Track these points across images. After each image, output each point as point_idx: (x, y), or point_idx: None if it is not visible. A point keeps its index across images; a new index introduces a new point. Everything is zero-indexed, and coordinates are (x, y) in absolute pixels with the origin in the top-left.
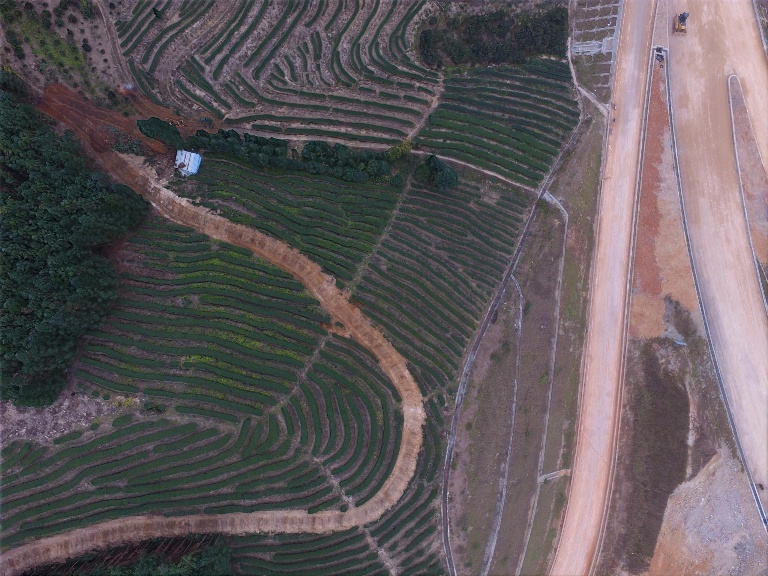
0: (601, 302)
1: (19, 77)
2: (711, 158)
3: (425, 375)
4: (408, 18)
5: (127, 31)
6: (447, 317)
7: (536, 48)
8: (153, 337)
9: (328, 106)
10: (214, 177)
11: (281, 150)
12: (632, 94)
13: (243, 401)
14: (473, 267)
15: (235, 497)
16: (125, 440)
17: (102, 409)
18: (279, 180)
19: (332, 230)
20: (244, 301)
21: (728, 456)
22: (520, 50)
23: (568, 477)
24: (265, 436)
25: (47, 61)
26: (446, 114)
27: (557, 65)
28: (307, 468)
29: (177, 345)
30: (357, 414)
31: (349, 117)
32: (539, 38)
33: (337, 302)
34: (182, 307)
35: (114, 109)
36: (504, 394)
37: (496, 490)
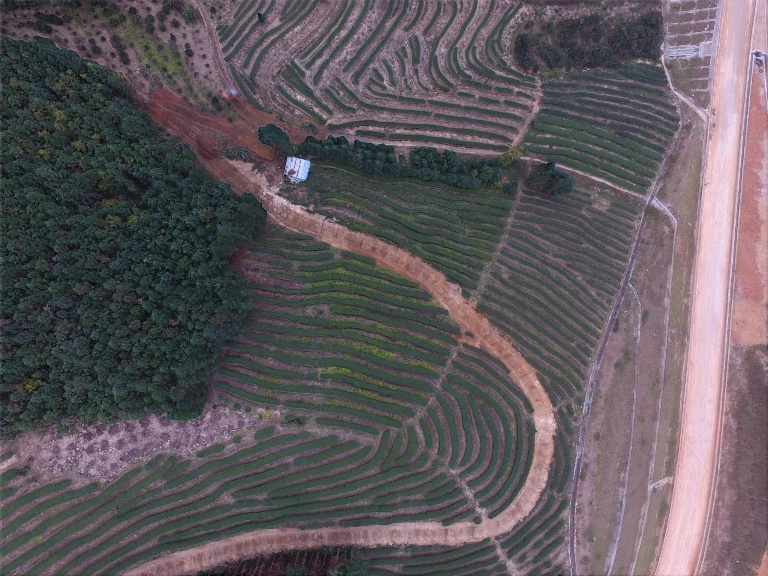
0: (702, 309)
1: (130, 83)
2: None
3: (555, 385)
4: (504, 22)
5: (228, 36)
6: (571, 326)
7: (630, 52)
8: (288, 348)
9: (429, 111)
10: (324, 184)
11: (394, 157)
12: (731, 99)
13: (381, 413)
14: (592, 275)
15: (372, 510)
16: (266, 453)
17: (244, 421)
18: (390, 187)
19: (451, 238)
20: (374, 311)
21: None
22: (613, 54)
23: (670, 485)
24: (403, 448)
25: (151, 66)
26: (549, 119)
27: (652, 69)
28: (444, 480)
29: (313, 356)
30: (492, 425)
31: (452, 123)
32: (634, 42)
33: (464, 311)
34: (313, 317)
35: (218, 115)
36: (625, 403)
37: (616, 500)
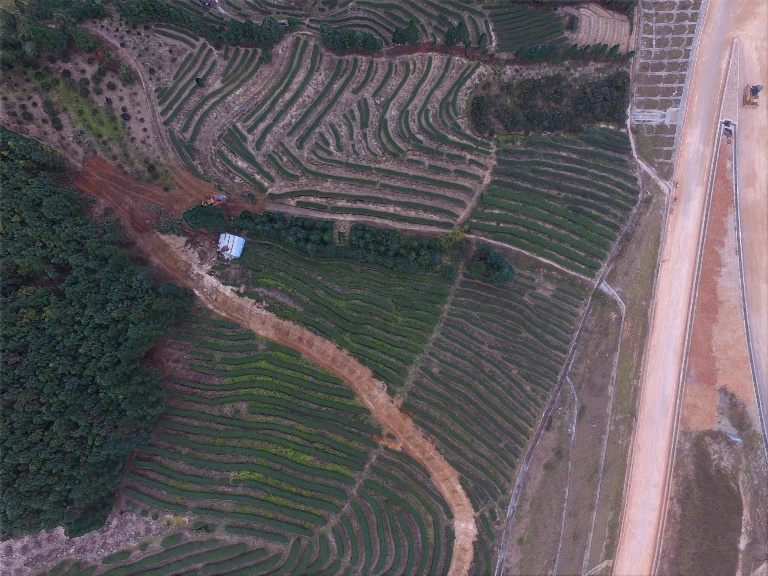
0: (652, 390)
1: (58, 155)
2: None
3: (478, 490)
4: (460, 83)
5: (167, 98)
6: (500, 425)
7: (594, 115)
8: (201, 450)
9: (375, 181)
10: (258, 261)
11: (329, 237)
12: (696, 171)
13: (293, 520)
14: (527, 369)
15: None
16: (173, 559)
17: (150, 528)
18: (326, 267)
19: (382, 328)
20: (293, 410)
21: None
22: (576, 116)
23: (610, 568)
24: (314, 556)
25: (85, 132)
26: (499, 192)
27: (616, 135)
28: None
29: (226, 459)
30: (408, 533)
31: (397, 194)
32: (598, 105)
33: (388, 411)
34: (230, 416)
35: (154, 183)
36: (555, 502)
37: None
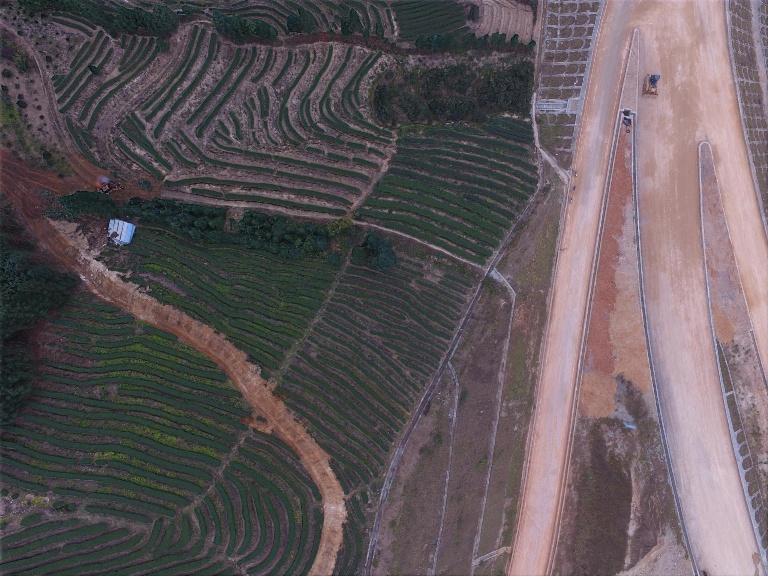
0: (551, 378)
1: None
2: (675, 231)
3: (348, 472)
4: (362, 72)
5: (64, 86)
6: (376, 409)
7: (498, 105)
8: (67, 431)
9: (273, 168)
10: (148, 247)
11: (215, 224)
12: (595, 160)
13: (156, 500)
14: (408, 354)
15: None
16: (35, 538)
17: (11, 508)
18: (214, 253)
19: (262, 313)
20: (163, 392)
21: (672, 541)
22: (481, 106)
23: (508, 554)
24: (178, 536)
25: None
26: (395, 180)
27: (519, 124)
28: (221, 567)
29: (91, 440)
30: (274, 514)
31: (293, 182)
32: (501, 95)
33: (261, 394)
34: (99, 398)
35: (49, 170)
36: (434, 486)
37: None
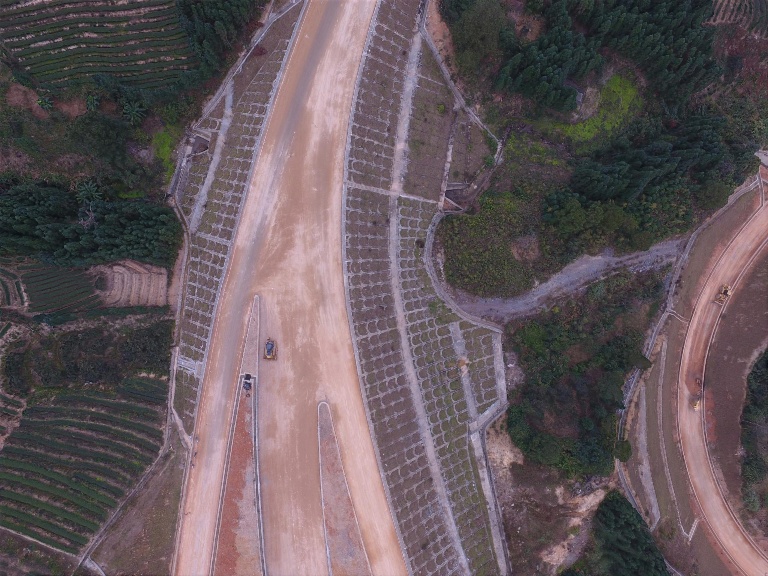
0: None
1: None
2: (296, 490)
3: None
4: None
5: None
6: None
7: (137, 363)
8: None
9: None
10: None
11: None
12: (218, 424)
13: None
14: None
15: None
16: None
17: None
18: None
19: None
20: None
21: None
22: (123, 363)
23: None
24: None
25: None
26: (5, 462)
27: (154, 384)
28: None
29: None
30: None
31: None
32: (138, 355)
33: None
34: None
35: None
36: None
37: None
